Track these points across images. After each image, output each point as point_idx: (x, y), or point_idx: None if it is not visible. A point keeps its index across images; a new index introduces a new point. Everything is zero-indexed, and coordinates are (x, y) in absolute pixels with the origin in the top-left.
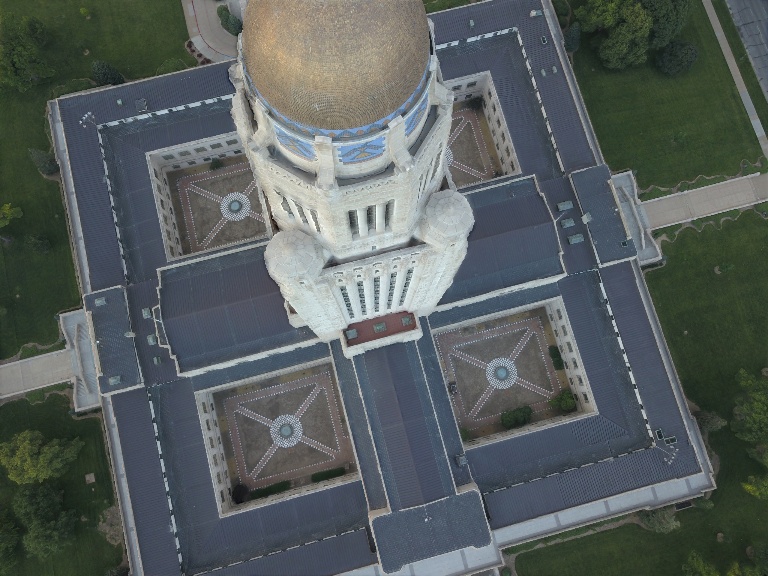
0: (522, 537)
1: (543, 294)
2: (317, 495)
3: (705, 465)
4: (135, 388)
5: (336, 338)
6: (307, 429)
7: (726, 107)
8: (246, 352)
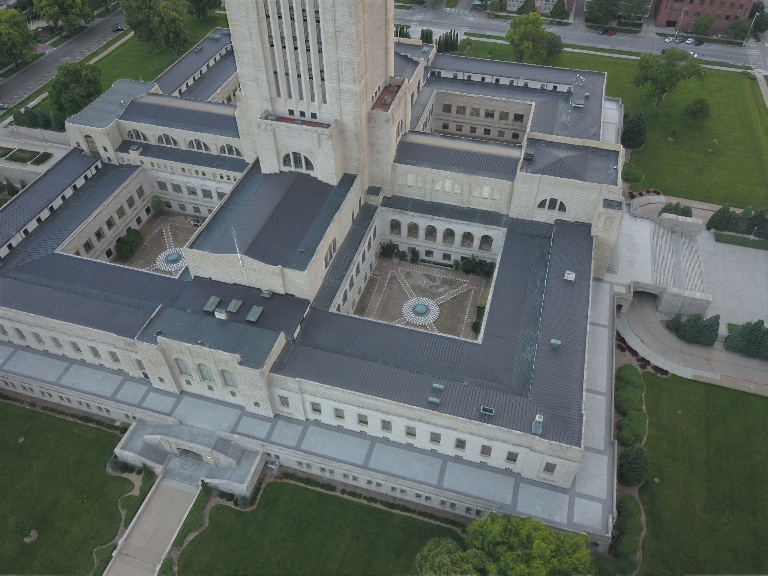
0: None
1: None
2: None
3: None
4: None
5: None
6: None
7: None
8: None
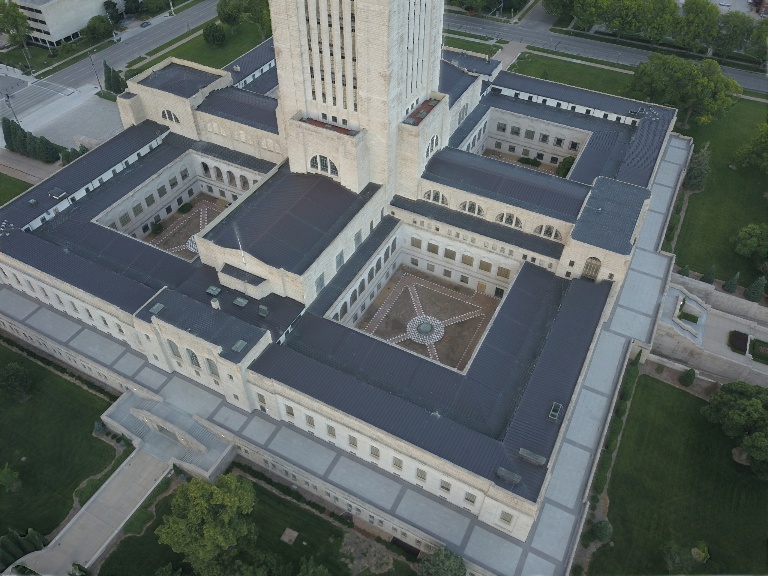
0: (658, 236)
1: (481, 113)
2: (511, 296)
3: (672, 136)
4: (266, 342)
5: (392, 193)
6: (439, 316)
7: (448, 41)
8: (338, 233)
